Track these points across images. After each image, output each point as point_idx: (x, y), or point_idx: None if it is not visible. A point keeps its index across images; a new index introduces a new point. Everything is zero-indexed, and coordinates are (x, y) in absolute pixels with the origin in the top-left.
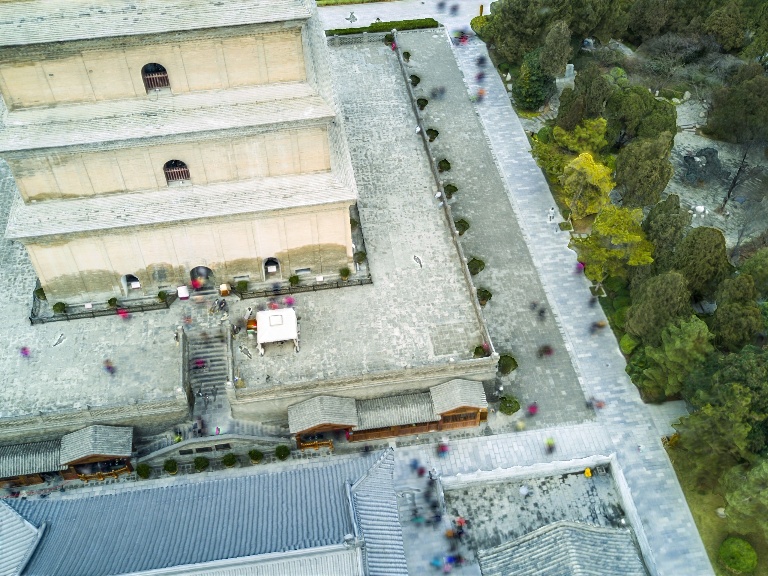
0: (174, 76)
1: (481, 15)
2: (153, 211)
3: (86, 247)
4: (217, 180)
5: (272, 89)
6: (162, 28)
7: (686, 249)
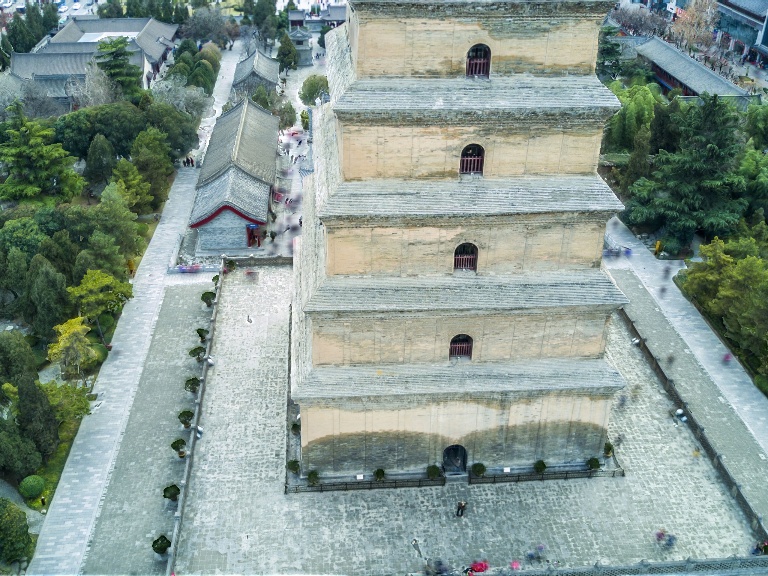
0: None
1: None
2: None
3: None
4: None
5: None
6: None
7: None
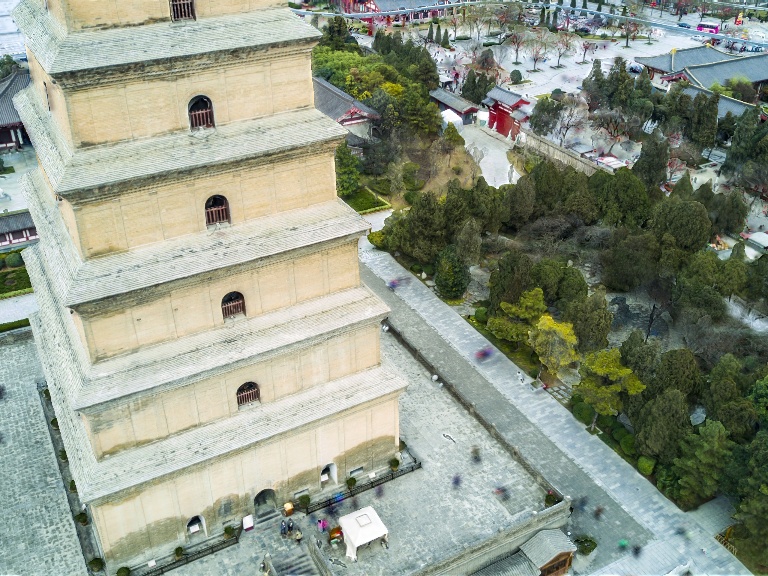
0: (250, 301)
1: (370, 232)
2: (229, 439)
3: (157, 495)
4: (284, 395)
5: (333, 298)
6: (250, 257)
7: (666, 371)
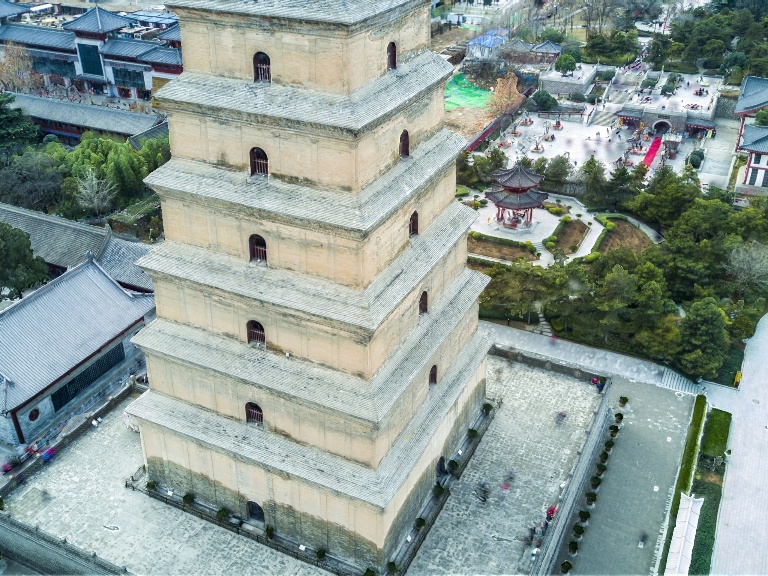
0: None
1: None
2: None
3: None
4: None
5: None
6: None
7: None
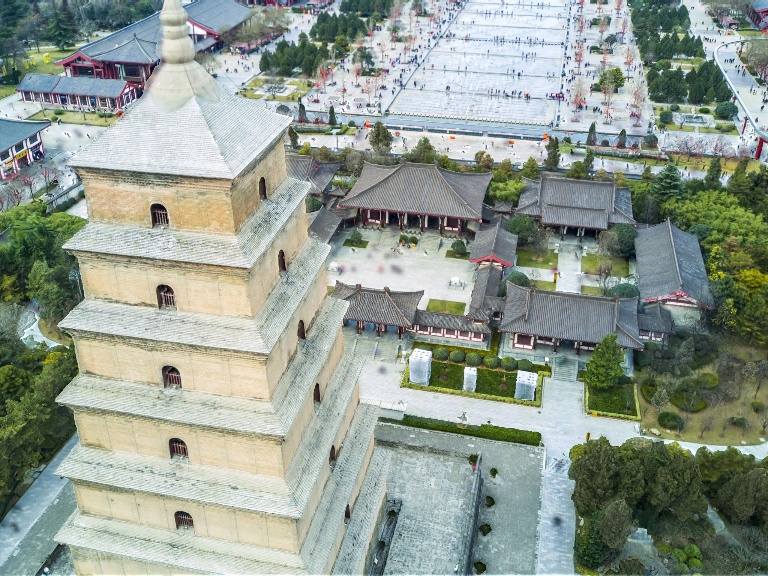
0: (198, 524)
1: None
2: None
3: None
4: None
5: (271, 553)
6: (189, 496)
7: None
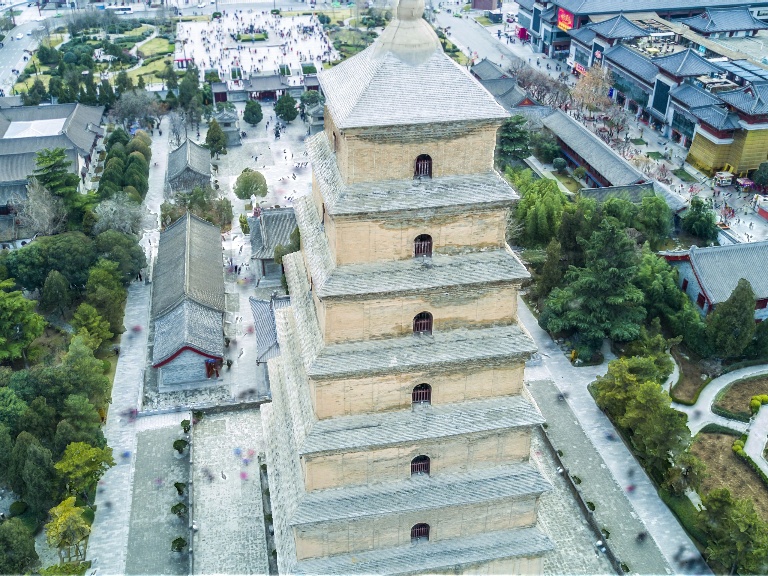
0: None
1: None
2: None
3: None
4: None
5: None
6: None
7: (42, 447)
